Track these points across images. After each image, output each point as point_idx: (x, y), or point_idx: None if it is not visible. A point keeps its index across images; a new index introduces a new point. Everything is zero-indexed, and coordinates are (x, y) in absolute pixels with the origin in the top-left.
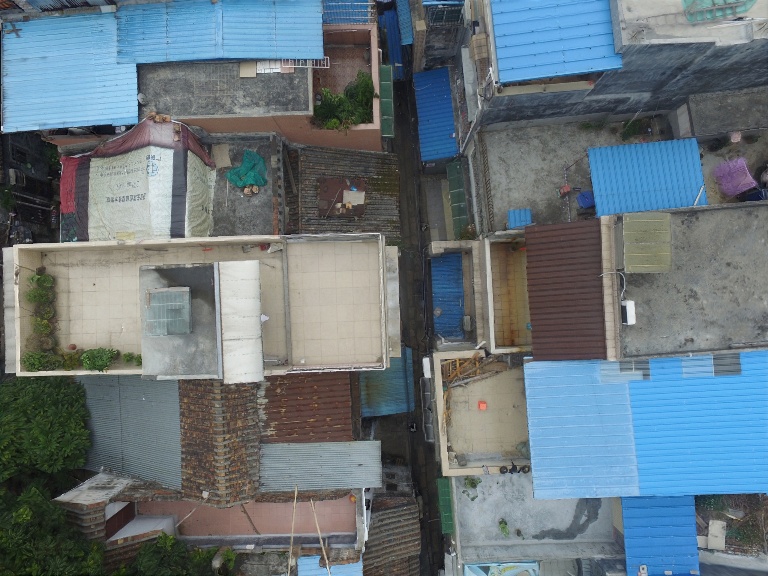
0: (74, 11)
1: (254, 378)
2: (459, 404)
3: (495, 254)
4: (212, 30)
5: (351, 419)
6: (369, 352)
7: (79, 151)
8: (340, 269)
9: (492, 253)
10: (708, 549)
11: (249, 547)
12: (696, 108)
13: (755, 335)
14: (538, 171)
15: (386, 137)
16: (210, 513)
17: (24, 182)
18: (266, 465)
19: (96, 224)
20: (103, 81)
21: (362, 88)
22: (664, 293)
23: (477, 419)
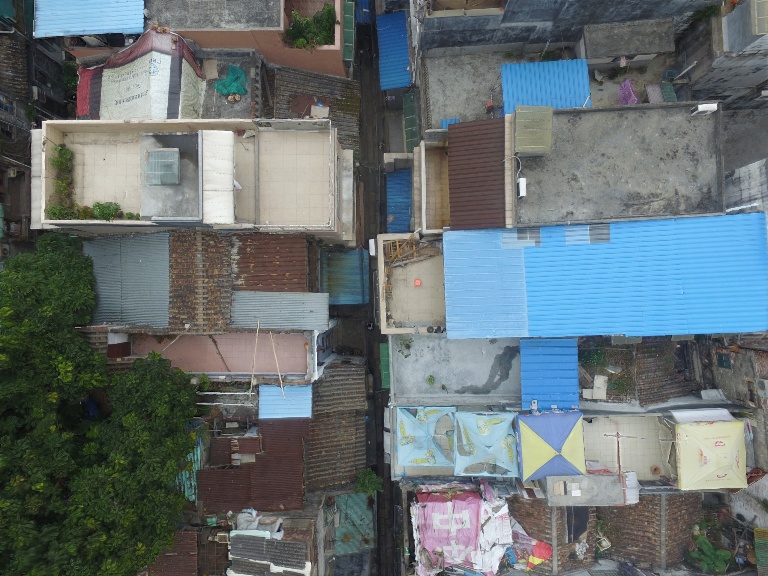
0: None
1: (226, 221)
2: (399, 281)
3: (432, 158)
4: None
5: (306, 276)
6: (321, 219)
7: (94, 63)
8: (300, 153)
9: (429, 157)
10: (593, 399)
11: (221, 377)
12: (589, 37)
13: (621, 210)
14: (469, 91)
15: (347, 61)
16: (191, 354)
17: (44, 99)
18: (236, 307)
19: None
20: None
21: (326, 16)
22: (552, 176)
23: (413, 294)
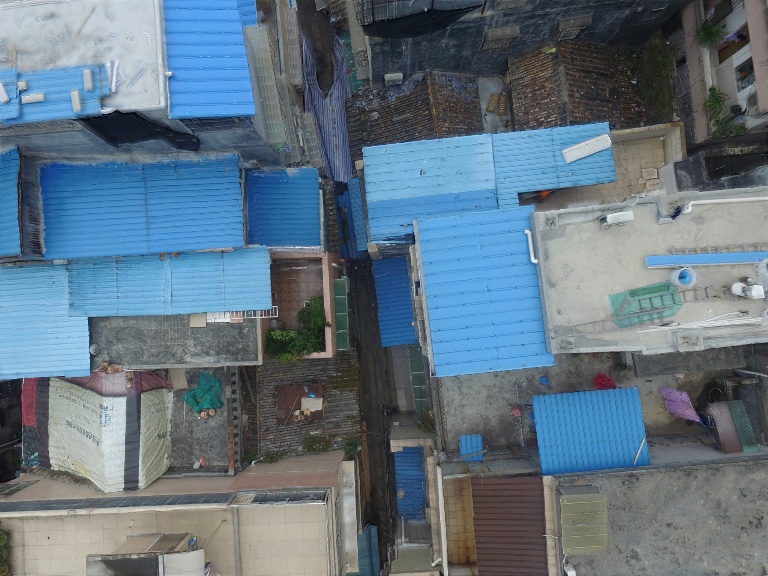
0: (26, 263)
1: None
2: None
3: None
4: (161, 287)
5: None
6: None
7: None
8: (290, 521)
9: None
10: None
11: None
12: None
13: None
14: (490, 387)
15: None
16: None
17: None
18: None
19: (56, 444)
20: (55, 333)
21: (314, 317)
22: (606, 554)
23: None
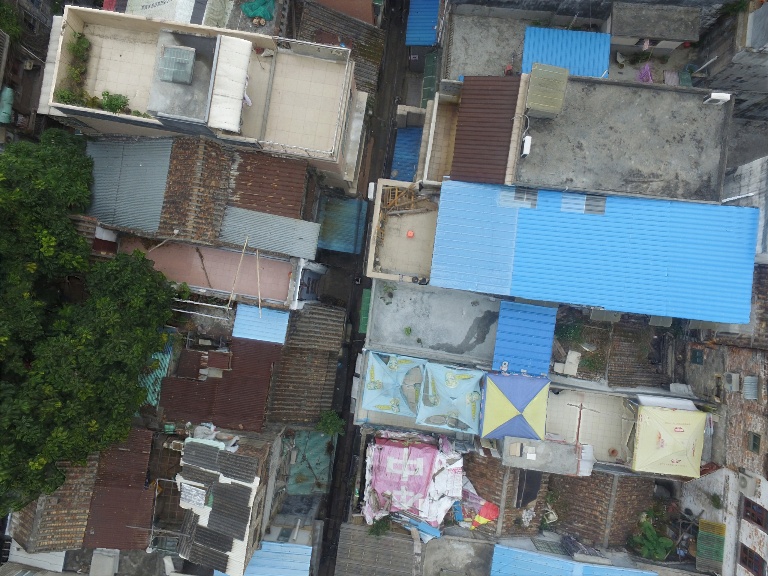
0: None
1: (231, 128)
2: (392, 230)
3: (444, 113)
4: None
5: (301, 204)
6: (325, 149)
7: None
8: (315, 80)
9: (442, 112)
10: (564, 374)
11: (202, 290)
12: (617, 14)
13: (620, 185)
14: (491, 54)
15: None
16: (176, 265)
17: (72, 1)
18: (227, 222)
19: None
20: None
21: None
22: (558, 141)
23: (404, 245)
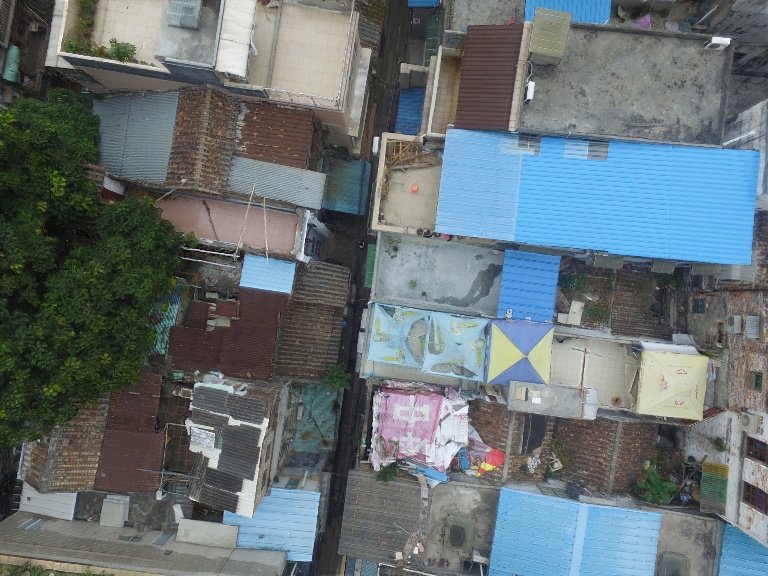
0: None
1: (238, 72)
2: (396, 185)
3: (447, 68)
4: None
5: None
6: None
7: None
8: (320, 31)
9: (445, 67)
10: (567, 324)
11: (209, 241)
12: None
13: (622, 130)
14: (494, 9)
15: None
16: (183, 218)
17: None
18: (234, 172)
19: None
20: None
21: None
22: (561, 87)
23: (408, 199)
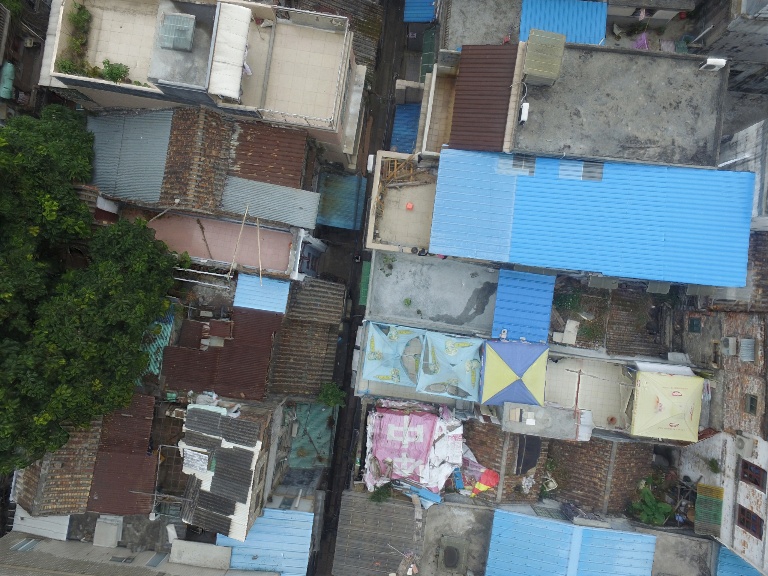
0: None
1: (231, 94)
2: (391, 202)
3: (442, 85)
4: None
5: (301, 174)
6: (324, 118)
7: None
8: (314, 51)
9: (440, 84)
10: (562, 343)
11: (203, 261)
12: None
13: (617, 151)
14: (489, 26)
15: None
16: (177, 236)
17: None
18: (228, 192)
19: None
20: None
21: None
22: (555, 108)
23: (403, 217)
